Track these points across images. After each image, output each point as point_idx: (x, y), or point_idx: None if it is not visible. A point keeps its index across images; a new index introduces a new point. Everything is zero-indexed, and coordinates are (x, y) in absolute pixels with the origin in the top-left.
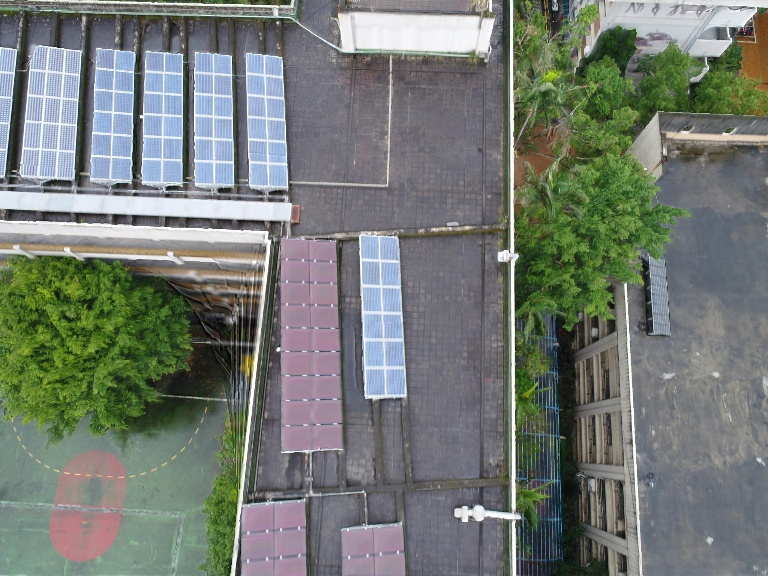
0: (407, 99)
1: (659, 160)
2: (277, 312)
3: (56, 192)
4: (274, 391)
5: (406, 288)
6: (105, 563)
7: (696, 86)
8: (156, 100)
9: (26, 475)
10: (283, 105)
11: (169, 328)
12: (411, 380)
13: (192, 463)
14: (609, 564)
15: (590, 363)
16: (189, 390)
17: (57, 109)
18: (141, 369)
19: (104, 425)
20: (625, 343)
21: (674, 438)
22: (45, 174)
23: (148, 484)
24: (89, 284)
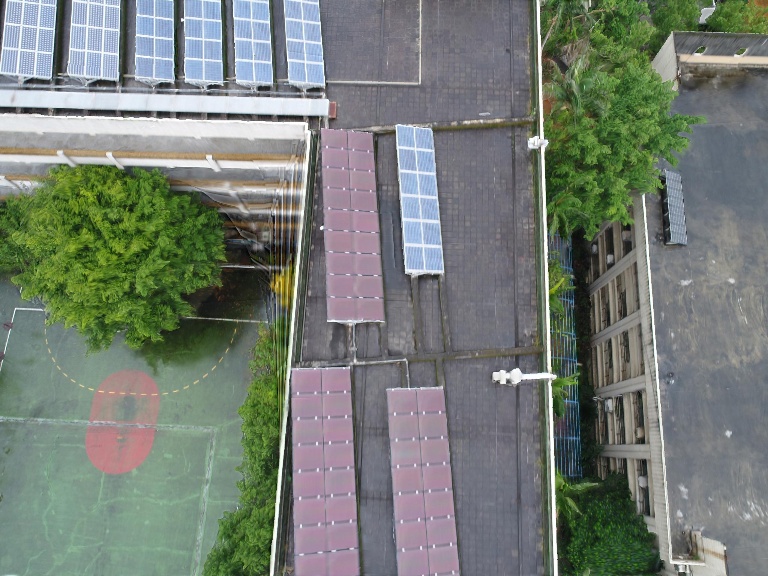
0: (436, 5)
1: (674, 76)
2: (317, 200)
3: (101, 92)
4: (317, 271)
5: (440, 177)
6: (141, 475)
7: (703, 30)
8: (196, 5)
9: (61, 394)
10: (318, 10)
11: (204, 239)
12: (447, 260)
13: (223, 381)
14: (628, 474)
15: (605, 291)
16: (219, 312)
17: (100, 15)
18: (176, 282)
19: (140, 337)
20: (644, 251)
21: (692, 340)
22: (91, 74)
23: (181, 401)
24: (129, 190)
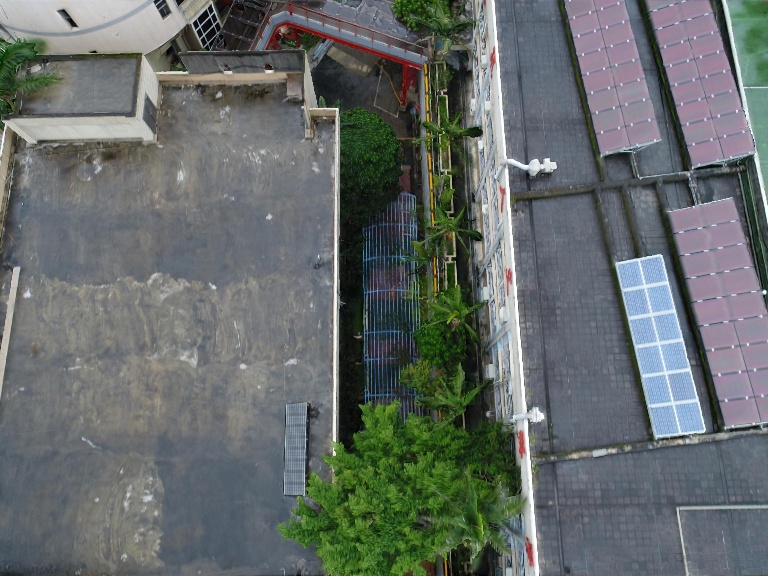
0: None
1: None
2: None
3: None
4: None
5: (632, 380)
6: None
7: None
8: None
9: None
10: None
11: None
12: (610, 283)
13: None
14: None
15: None
16: None
17: None
18: None
19: None
20: None
21: (292, 302)
22: None
23: None
24: None
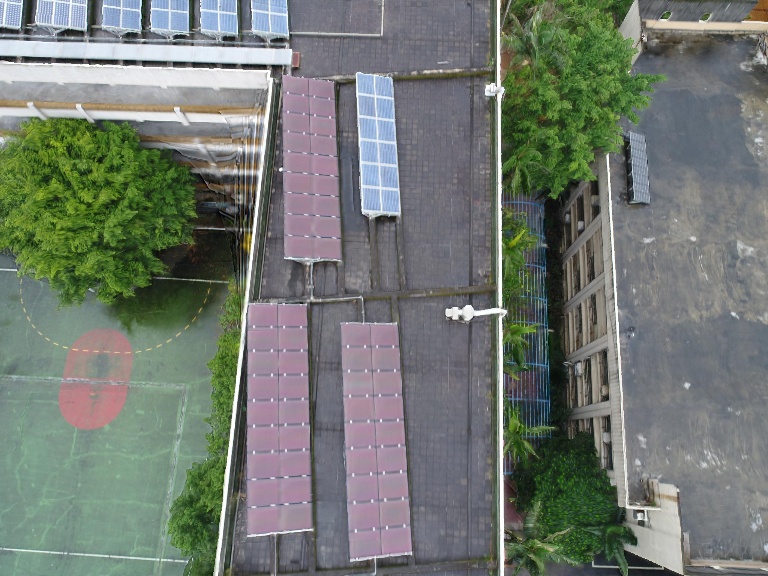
0: None
1: (639, 39)
2: (279, 146)
3: (69, 41)
4: (277, 214)
5: (400, 124)
6: (113, 431)
7: None
8: None
9: (36, 352)
10: None
11: (175, 194)
12: (405, 203)
13: (196, 339)
14: (594, 433)
15: (577, 258)
16: (192, 273)
17: None
18: (147, 239)
19: (112, 293)
20: (607, 209)
21: (654, 295)
22: (59, 23)
23: (154, 359)
24: (99, 142)
